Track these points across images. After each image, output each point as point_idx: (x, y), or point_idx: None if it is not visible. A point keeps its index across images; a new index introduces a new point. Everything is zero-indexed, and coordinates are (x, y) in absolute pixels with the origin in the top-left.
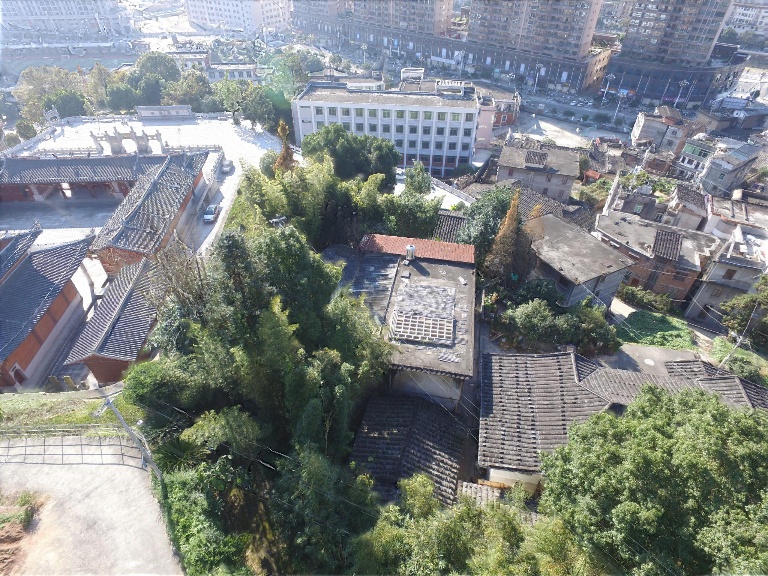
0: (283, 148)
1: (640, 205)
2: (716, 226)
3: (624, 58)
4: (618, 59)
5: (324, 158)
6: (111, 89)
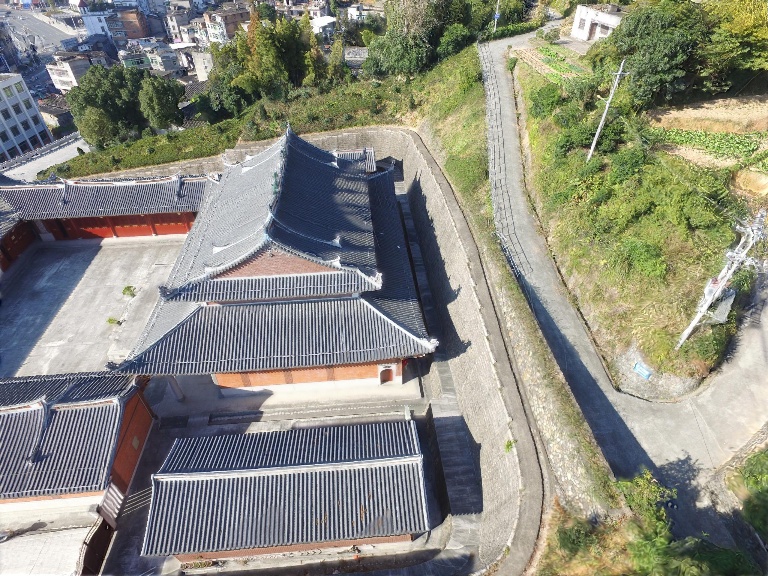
0: (256, 11)
1: None
2: None
3: None
4: None
5: (240, 27)
6: None
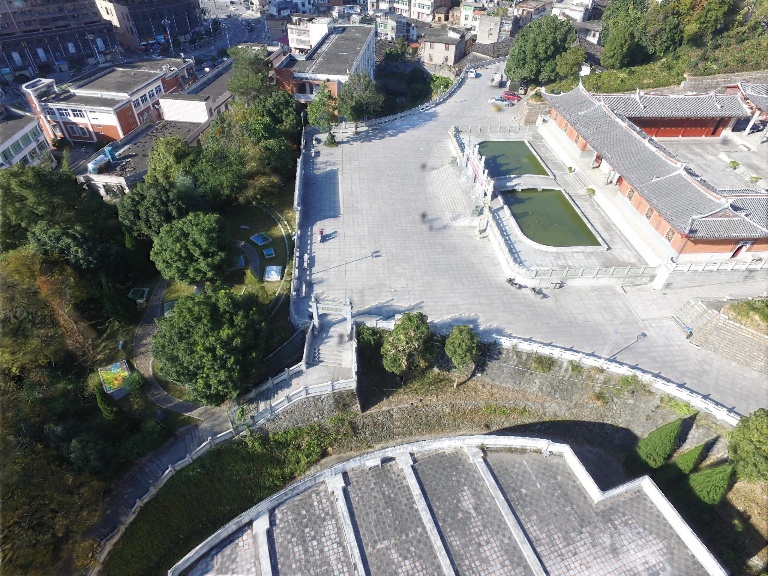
0: None
1: (513, 22)
2: (534, 14)
3: (140, 5)
4: (136, 8)
5: None
6: (209, 233)
